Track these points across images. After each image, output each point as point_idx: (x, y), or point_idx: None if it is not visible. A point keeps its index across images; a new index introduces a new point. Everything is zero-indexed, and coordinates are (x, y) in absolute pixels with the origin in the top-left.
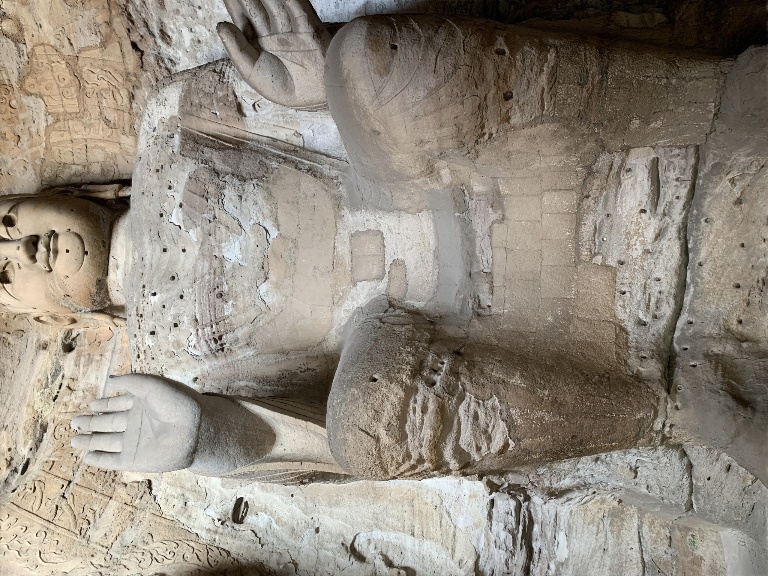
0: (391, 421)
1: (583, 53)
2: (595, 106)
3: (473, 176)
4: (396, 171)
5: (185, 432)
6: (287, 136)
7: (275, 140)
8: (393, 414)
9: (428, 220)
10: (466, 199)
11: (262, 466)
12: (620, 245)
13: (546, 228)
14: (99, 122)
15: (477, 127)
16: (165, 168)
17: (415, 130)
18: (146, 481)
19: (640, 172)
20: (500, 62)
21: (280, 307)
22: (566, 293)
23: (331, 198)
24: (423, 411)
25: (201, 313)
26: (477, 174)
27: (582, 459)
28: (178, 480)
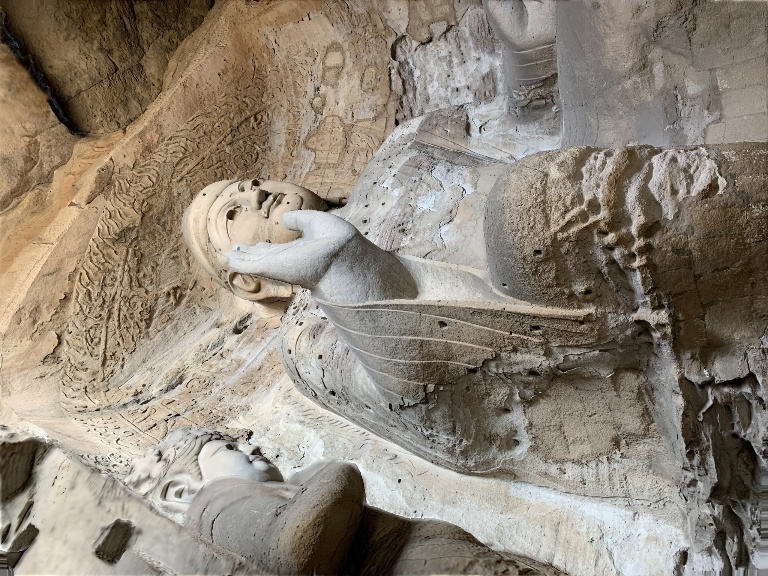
0: (566, 160)
1: None
2: None
3: (688, 73)
4: (608, 70)
5: (334, 239)
6: (502, 158)
7: (490, 158)
8: (570, 156)
9: None
10: (678, 107)
11: (395, 301)
12: None
13: None
14: (348, 171)
15: None
16: (392, 157)
17: None
18: (249, 429)
19: None
20: None
21: (456, 246)
22: None
23: None
24: (607, 155)
25: (379, 244)
26: (693, 69)
27: None
28: (280, 438)
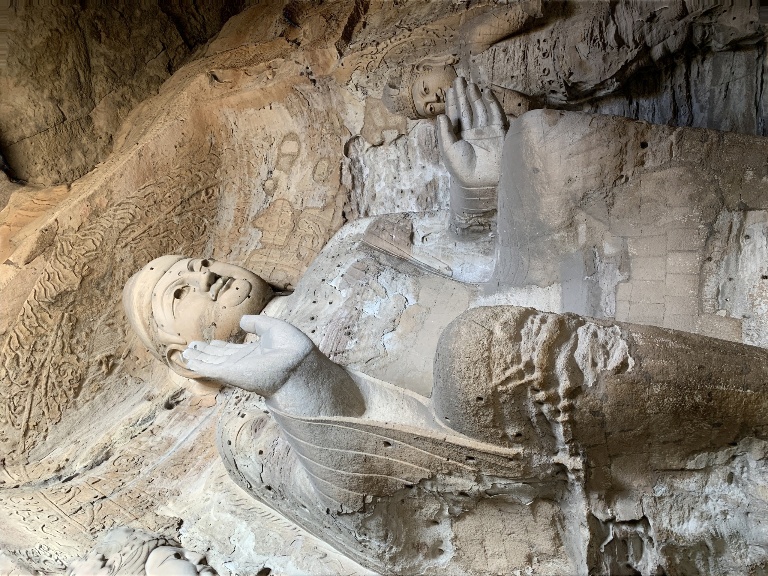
0: (508, 321)
1: (703, 129)
2: (714, 157)
3: (606, 236)
4: (541, 223)
5: (293, 353)
6: (440, 268)
7: (430, 267)
8: (511, 317)
9: (556, 294)
10: (596, 262)
11: (345, 418)
12: (744, 303)
13: (670, 287)
14: (293, 254)
15: (617, 168)
16: (340, 255)
17: (567, 167)
18: (179, 518)
19: (758, 239)
20: (639, 126)
21: (397, 355)
22: (690, 330)
23: (469, 291)
24: (542, 321)
25: (325, 344)
26: (609, 234)
27: (711, 477)
28: (211, 529)
